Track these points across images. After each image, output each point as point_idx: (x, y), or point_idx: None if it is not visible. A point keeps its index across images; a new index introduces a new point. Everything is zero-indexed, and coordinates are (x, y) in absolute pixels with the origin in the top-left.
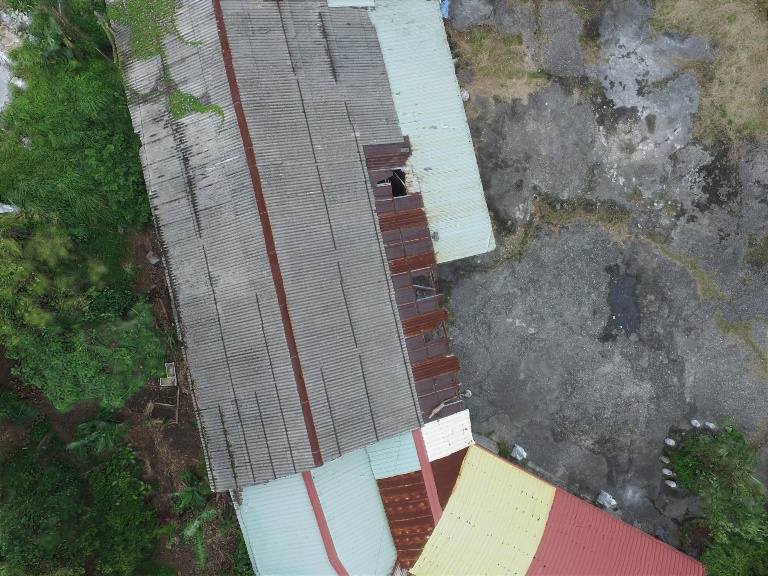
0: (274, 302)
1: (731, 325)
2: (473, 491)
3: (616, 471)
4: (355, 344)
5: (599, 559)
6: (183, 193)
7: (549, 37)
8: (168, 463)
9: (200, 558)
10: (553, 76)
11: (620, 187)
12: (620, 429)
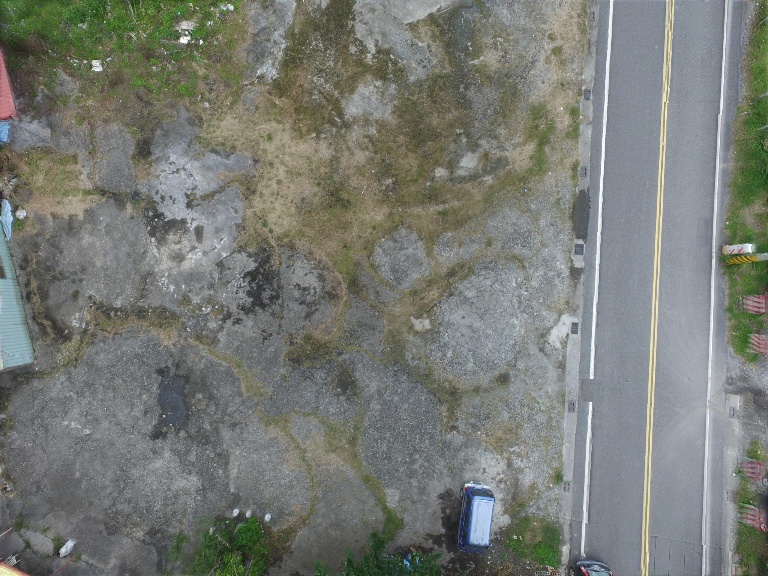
0: None
1: (272, 419)
2: None
3: (165, 560)
4: None
5: None
6: None
7: (103, 156)
8: None
9: None
10: (107, 192)
11: (170, 294)
12: (169, 520)
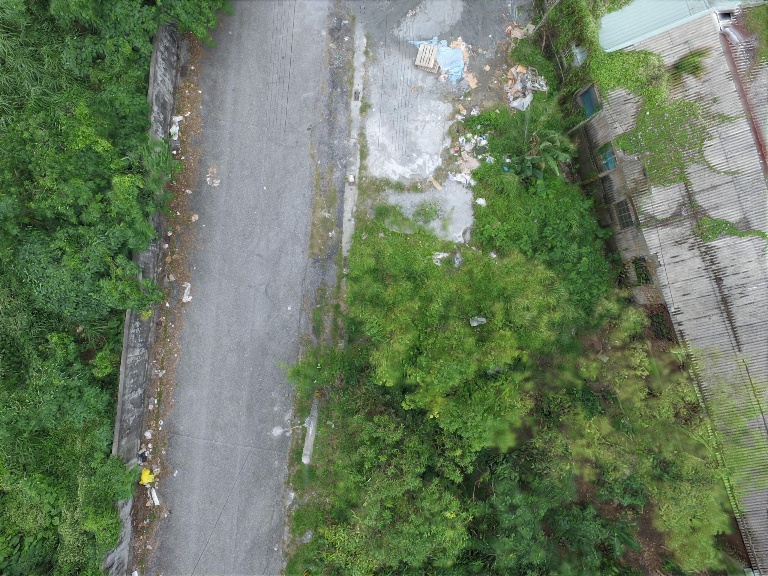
0: None
1: None
2: None
3: None
4: None
5: None
6: (715, 310)
7: None
8: (641, 552)
9: None
10: None
11: None
12: None
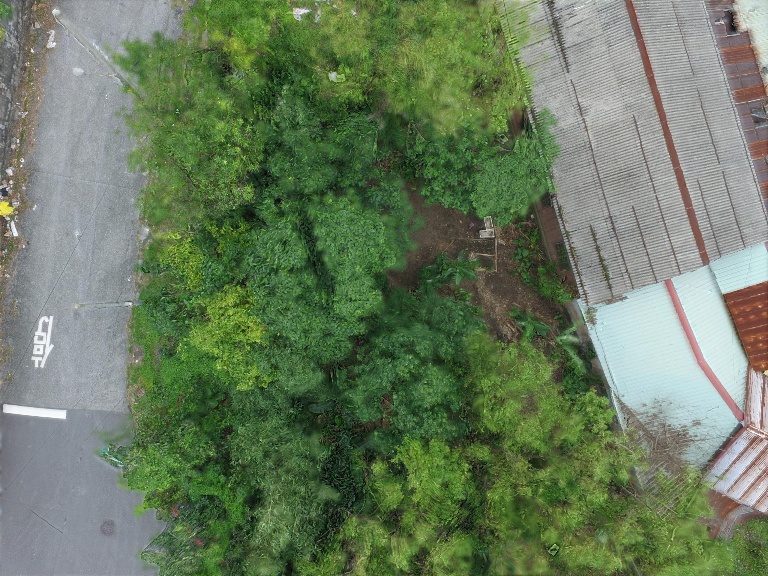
0: (654, 120)
1: None
2: None
3: None
4: (718, 161)
5: None
6: (547, 34)
7: None
8: (493, 307)
9: (578, 364)
10: None
11: None
12: None
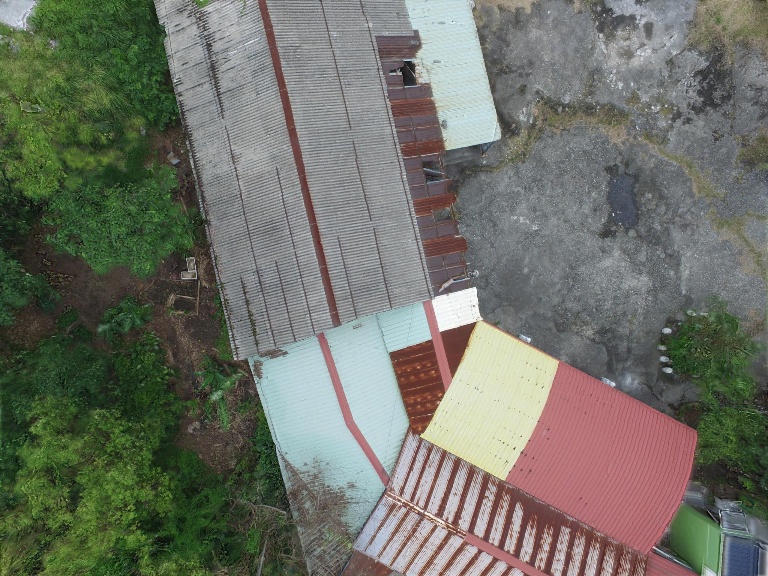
0: (294, 174)
1: (725, 221)
2: (481, 361)
3: (616, 359)
4: (369, 218)
5: (600, 424)
6: (206, 78)
7: None
8: (189, 352)
9: (224, 422)
10: None
11: (619, 91)
12: (619, 320)
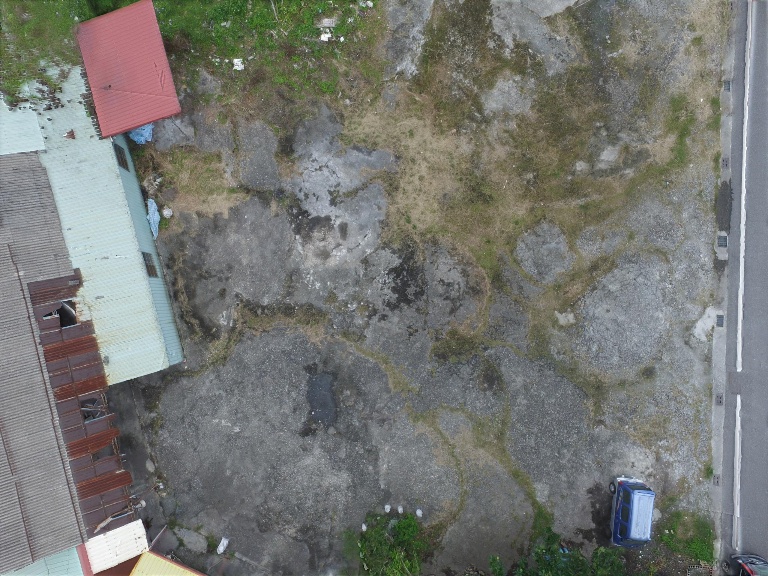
0: None
1: (420, 415)
2: None
3: (318, 556)
4: (11, 472)
5: None
6: None
7: (247, 155)
8: None
9: None
10: (251, 191)
11: (316, 291)
12: (320, 517)
